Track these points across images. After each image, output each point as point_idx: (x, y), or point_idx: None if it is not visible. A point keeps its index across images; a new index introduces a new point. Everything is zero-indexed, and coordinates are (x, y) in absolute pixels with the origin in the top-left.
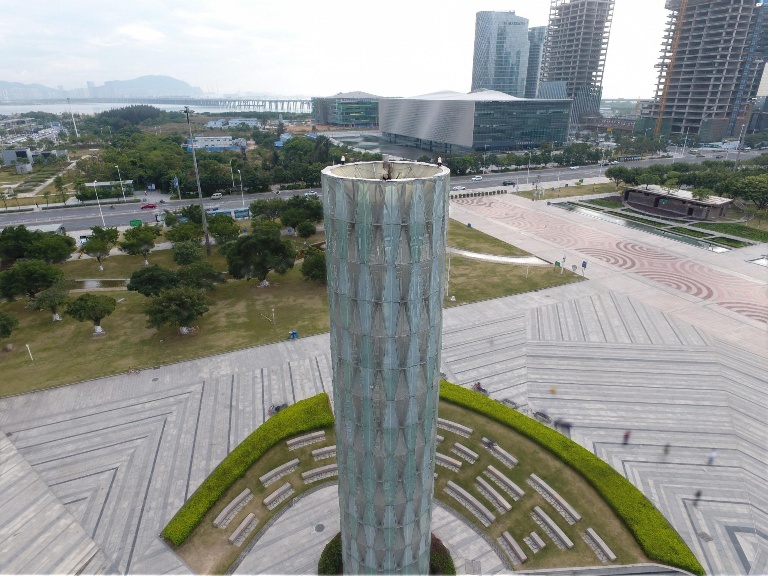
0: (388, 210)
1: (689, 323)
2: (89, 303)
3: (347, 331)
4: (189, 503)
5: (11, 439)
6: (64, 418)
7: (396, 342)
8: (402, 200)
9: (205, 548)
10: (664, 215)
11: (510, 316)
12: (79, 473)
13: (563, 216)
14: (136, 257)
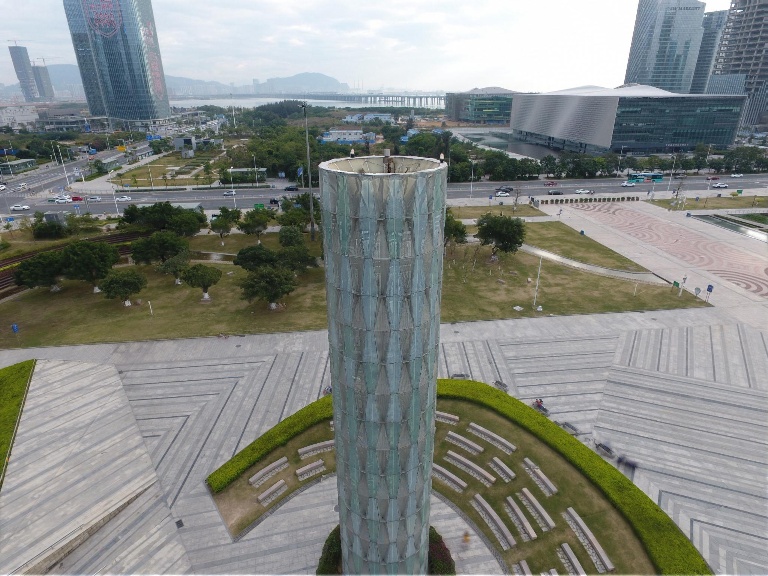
0: (365, 204)
1: None
2: (199, 272)
3: (334, 319)
4: (234, 458)
5: (121, 376)
6: (162, 366)
7: (375, 336)
8: (380, 195)
9: (237, 500)
10: None
11: (601, 335)
12: (160, 414)
13: (703, 231)
14: (252, 236)
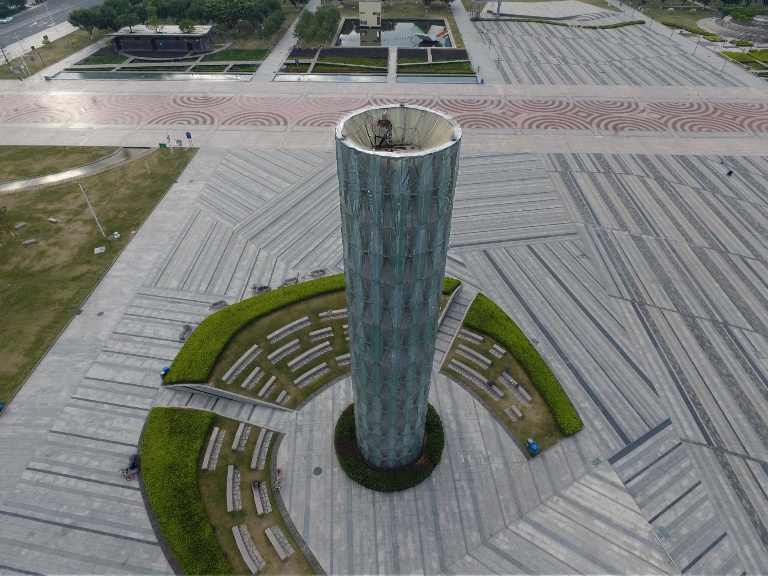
0: None
1: (300, 149)
2: None
3: (420, 281)
4: None
5: None
6: None
7: None
8: None
9: None
10: (173, 57)
11: (190, 218)
12: None
13: (85, 89)
14: None
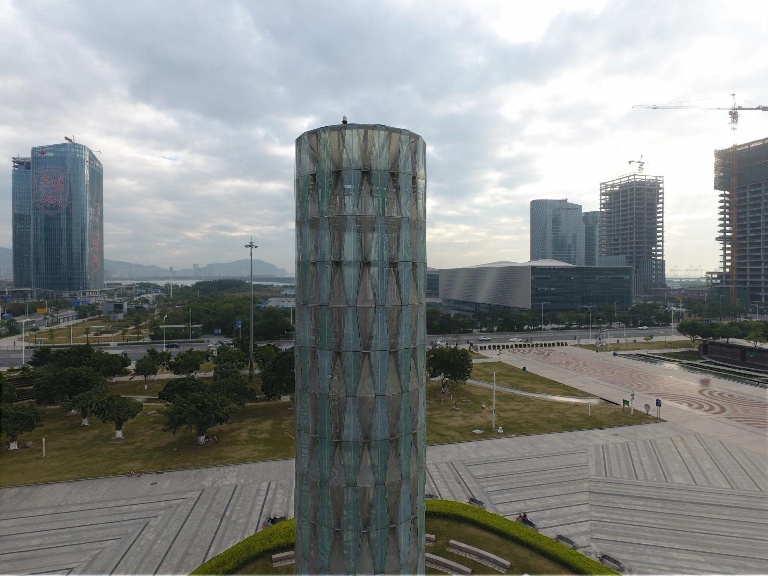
0: (349, 156)
1: None
2: (116, 402)
3: (306, 306)
4: None
5: None
6: (45, 512)
7: (358, 313)
8: (364, 147)
9: None
10: (755, 368)
11: (568, 451)
12: (30, 569)
13: (632, 365)
14: None
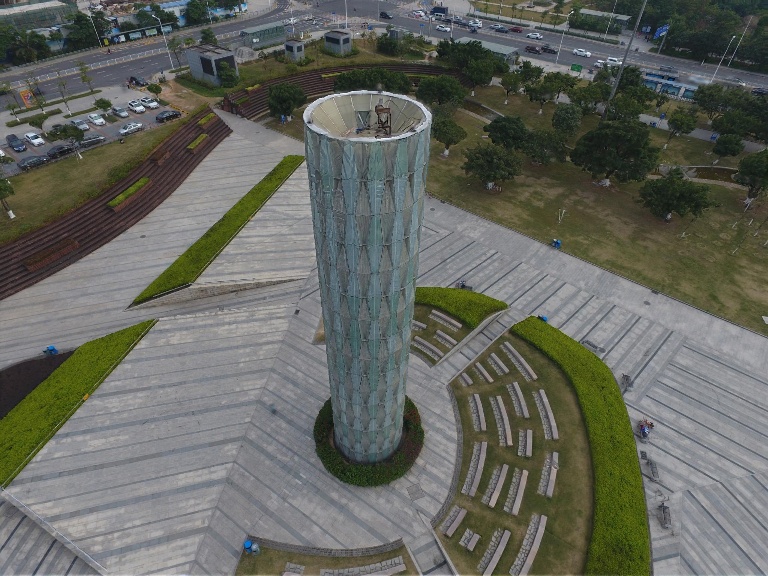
0: None
1: None
2: (445, 128)
3: None
4: None
5: None
6: None
7: (323, 262)
8: None
9: None
10: None
11: None
12: None
13: None
14: None
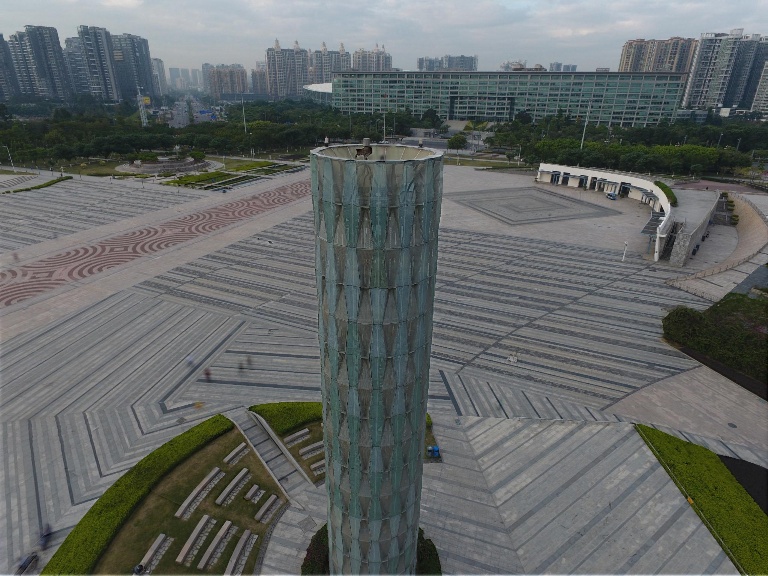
0: None
1: None
2: None
3: None
4: None
5: None
6: None
7: None
8: None
9: None
10: None
11: None
12: None
13: None
14: None
